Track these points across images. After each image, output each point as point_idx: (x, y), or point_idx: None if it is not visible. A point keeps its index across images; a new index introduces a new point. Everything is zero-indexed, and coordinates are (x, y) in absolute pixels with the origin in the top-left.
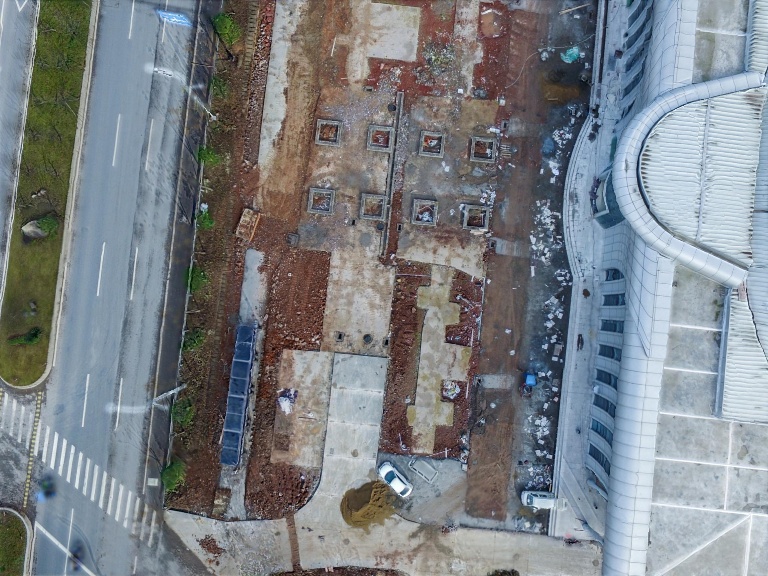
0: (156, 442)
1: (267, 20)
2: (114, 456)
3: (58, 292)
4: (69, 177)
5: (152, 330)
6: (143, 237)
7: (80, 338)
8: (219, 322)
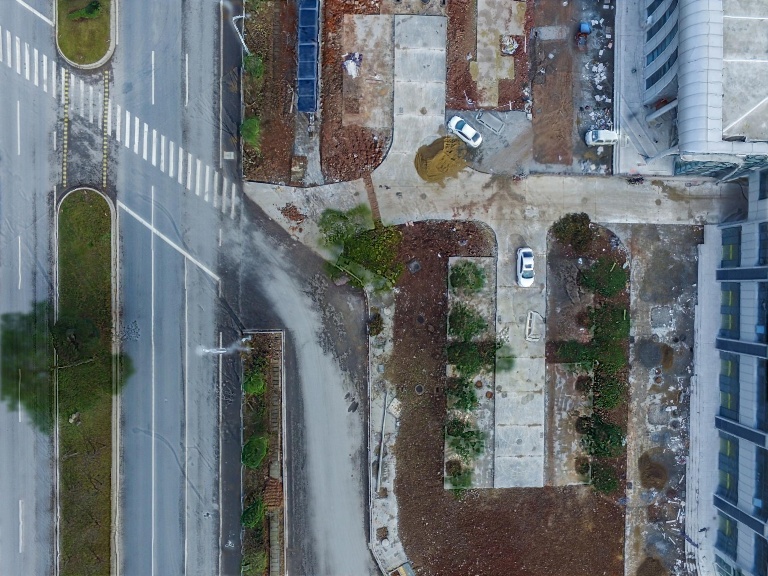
0: (228, 116)
1: None
2: (188, 132)
3: None
4: None
5: (212, 4)
6: None
7: (140, 15)
8: None
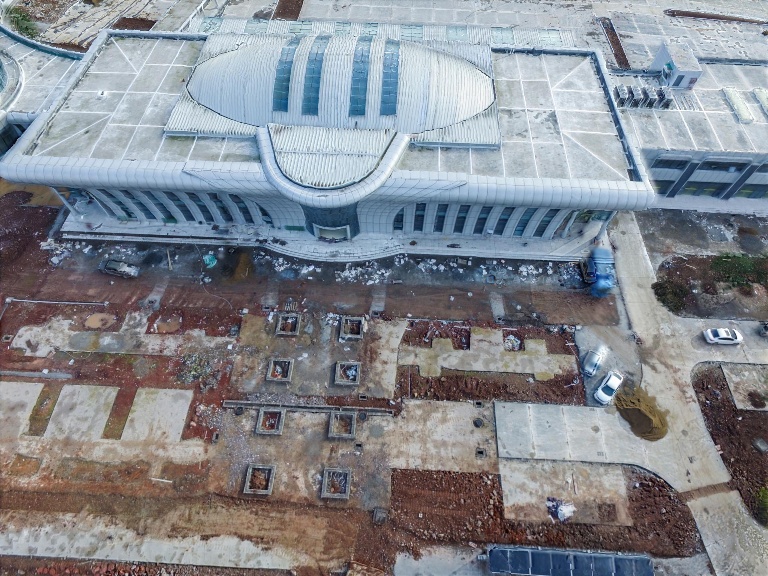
0: None
1: (111, 571)
2: None
3: None
4: None
5: None
6: None
7: None
8: None
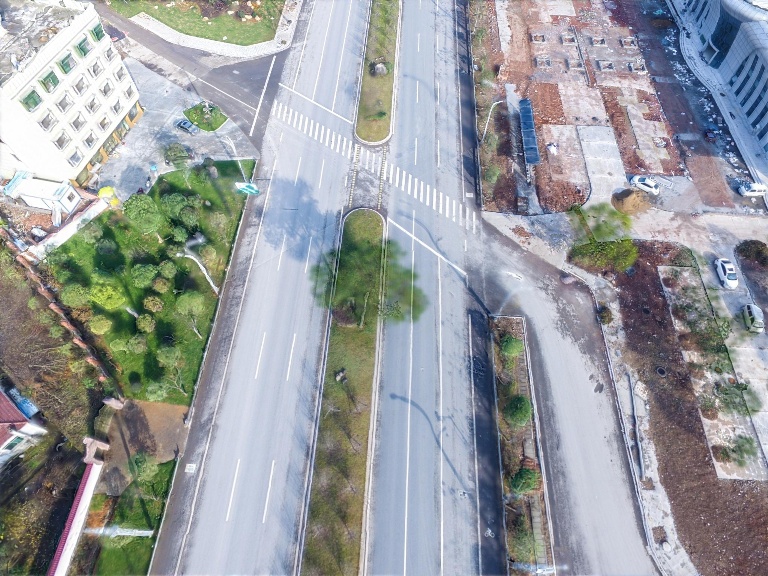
0: (467, 173)
1: (491, 4)
2: (440, 180)
3: (393, 100)
4: (395, 54)
5: (454, 118)
6: (441, 79)
7: (409, 121)
8: (495, 115)
